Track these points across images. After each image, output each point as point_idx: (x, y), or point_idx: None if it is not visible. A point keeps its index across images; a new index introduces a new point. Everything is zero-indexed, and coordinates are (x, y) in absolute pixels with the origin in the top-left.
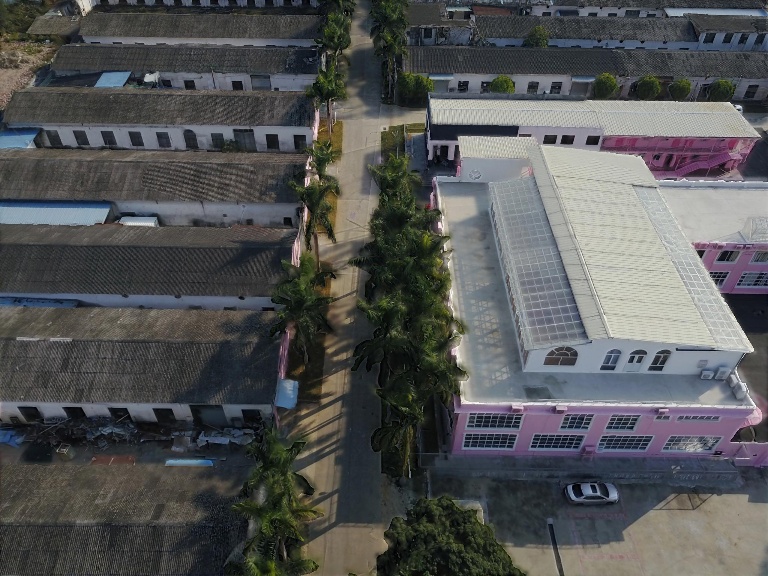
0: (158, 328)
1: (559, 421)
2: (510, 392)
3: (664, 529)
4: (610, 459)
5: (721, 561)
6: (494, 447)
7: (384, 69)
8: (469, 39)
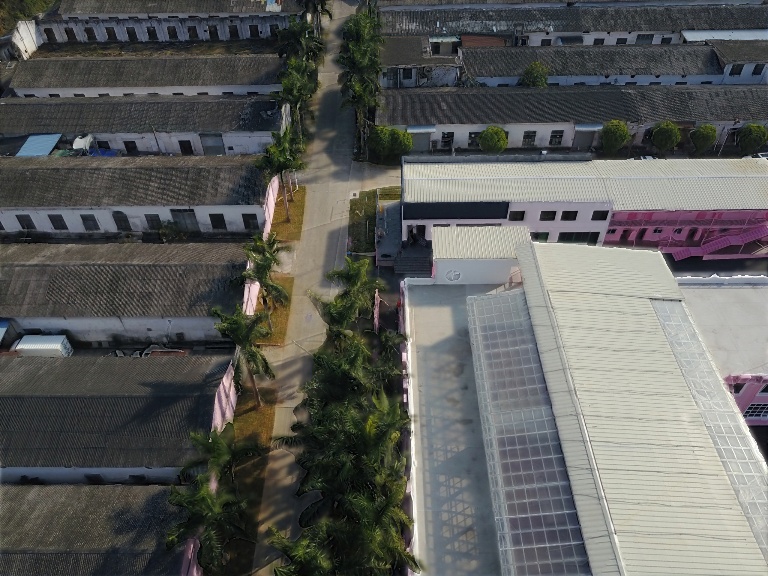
0: (32, 524)
1: None
2: None
3: None
4: None
5: None
6: None
7: None
8: (455, 79)
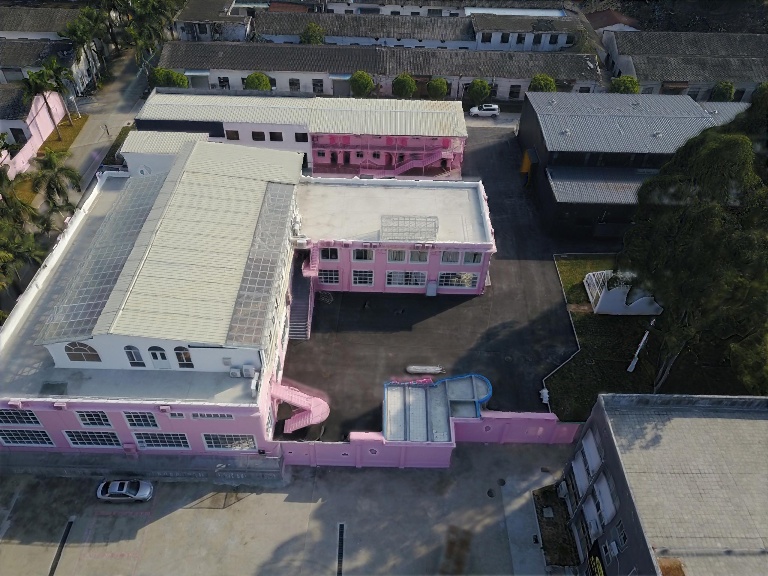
0: None
1: (74, 418)
2: (26, 388)
3: (181, 528)
4: (157, 457)
5: (220, 560)
6: (37, 443)
7: None
8: (245, 35)
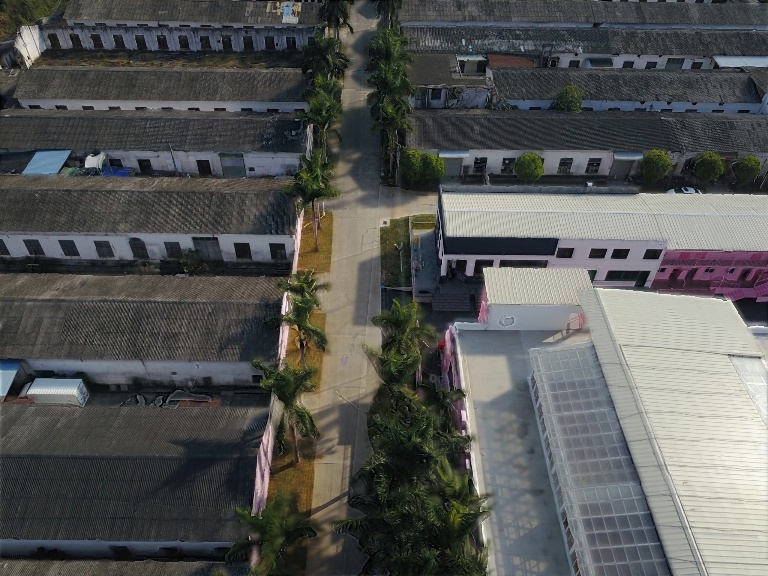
0: None
1: None
2: None
3: None
4: None
5: None
6: None
7: (383, 137)
8: (486, 101)
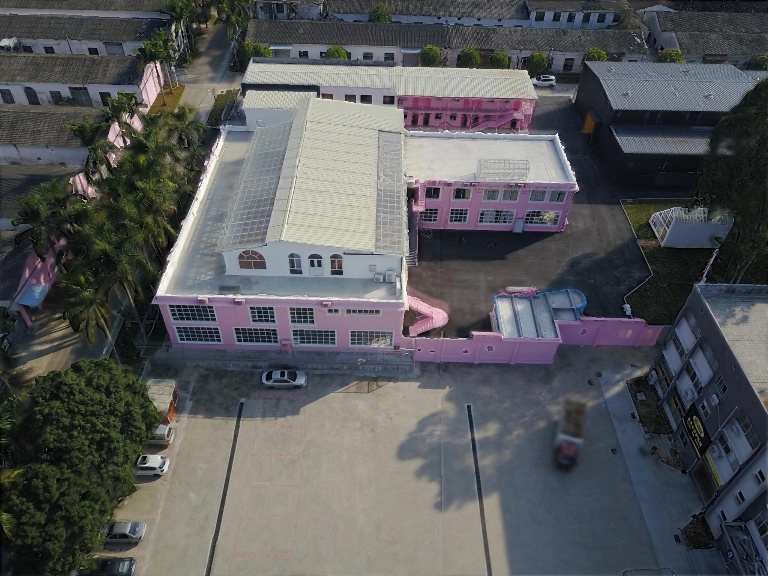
0: None
1: (247, 314)
2: (206, 289)
3: (336, 407)
4: (307, 353)
5: (373, 430)
6: (206, 341)
7: None
8: (319, 14)
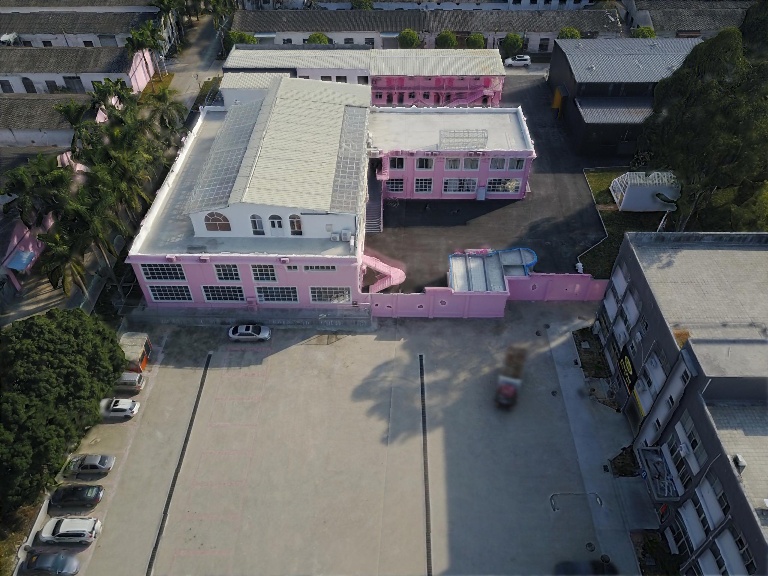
0: None
1: (212, 272)
2: (175, 249)
3: (296, 357)
4: (272, 310)
5: (329, 377)
6: (179, 300)
7: None
8: (303, 4)
